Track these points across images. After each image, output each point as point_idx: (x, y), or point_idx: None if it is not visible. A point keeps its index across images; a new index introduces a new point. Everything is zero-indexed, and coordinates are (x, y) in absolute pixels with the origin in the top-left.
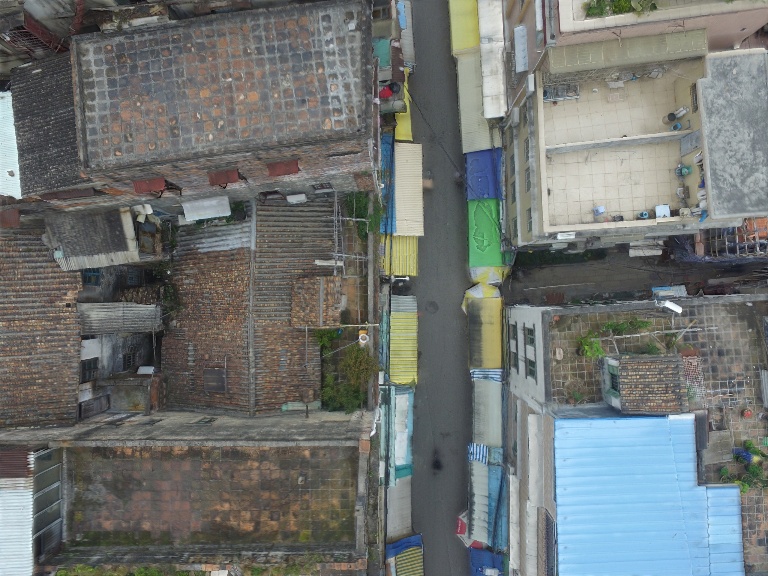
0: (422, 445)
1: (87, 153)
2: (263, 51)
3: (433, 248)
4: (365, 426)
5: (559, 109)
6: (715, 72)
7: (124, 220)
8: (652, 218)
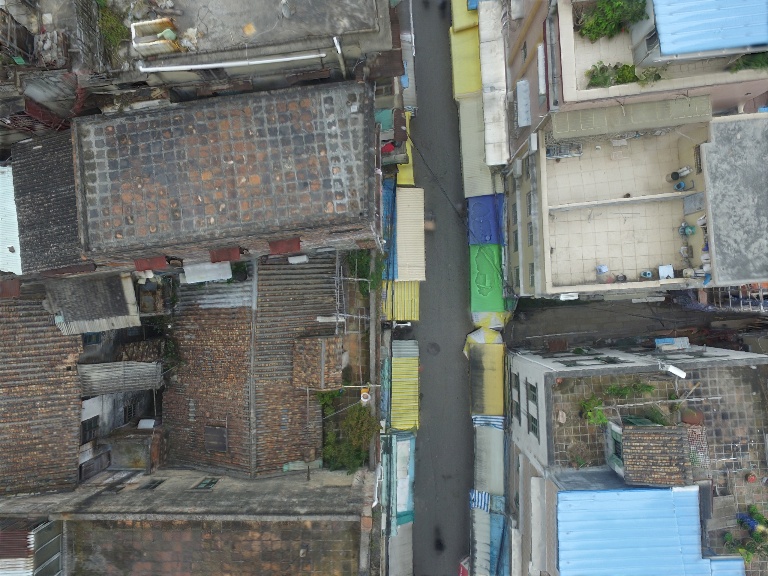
0: (423, 488)
1: (88, 235)
2: (265, 133)
3: (435, 289)
4: (367, 495)
5: (562, 166)
6: (719, 136)
7: (125, 285)
8: (655, 277)
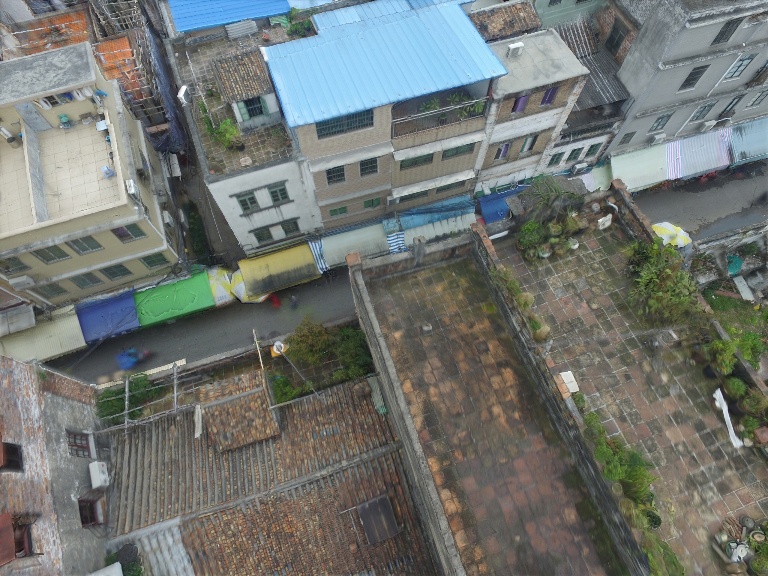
0: None
1: None
2: None
3: None
4: (352, 289)
5: None
6: None
7: None
8: None
